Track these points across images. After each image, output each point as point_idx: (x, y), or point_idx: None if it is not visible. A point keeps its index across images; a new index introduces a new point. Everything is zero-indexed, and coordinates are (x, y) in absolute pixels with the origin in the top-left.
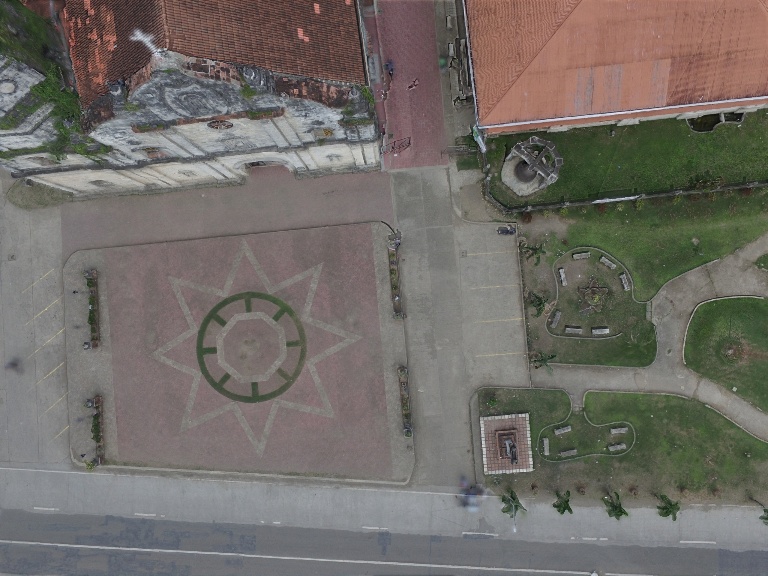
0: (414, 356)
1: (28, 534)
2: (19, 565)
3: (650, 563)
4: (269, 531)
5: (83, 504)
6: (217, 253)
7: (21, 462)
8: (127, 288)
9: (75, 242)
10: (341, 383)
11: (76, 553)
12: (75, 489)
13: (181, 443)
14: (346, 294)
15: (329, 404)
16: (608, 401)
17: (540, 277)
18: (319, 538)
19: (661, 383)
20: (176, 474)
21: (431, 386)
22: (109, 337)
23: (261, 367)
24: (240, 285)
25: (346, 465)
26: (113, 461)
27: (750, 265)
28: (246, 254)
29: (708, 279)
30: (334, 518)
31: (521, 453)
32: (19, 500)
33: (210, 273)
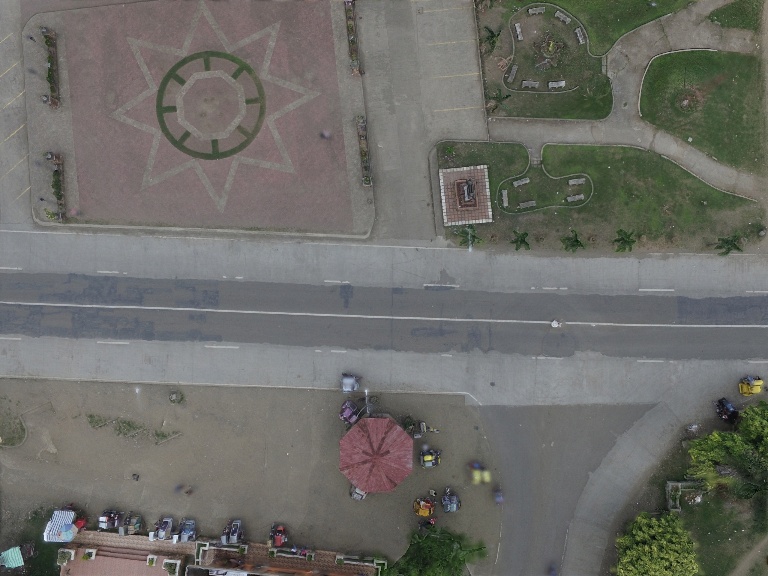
0: (373, 112)
1: None
2: None
3: (610, 311)
4: (231, 286)
5: (45, 263)
6: (175, 13)
7: None
8: (86, 49)
9: (34, 6)
10: (301, 139)
11: (39, 311)
12: (37, 248)
13: (142, 201)
14: (304, 51)
15: (289, 160)
16: (566, 153)
17: (496, 33)
18: (281, 292)
19: (618, 136)
20: (138, 232)
21: (390, 141)
22: (69, 98)
23: (221, 125)
24: (199, 44)
25: (307, 219)
26: (75, 219)
27: (703, 19)
28: (204, 14)
29: (662, 33)
30: (296, 272)
31: (480, 204)
32: None
33: (169, 33)
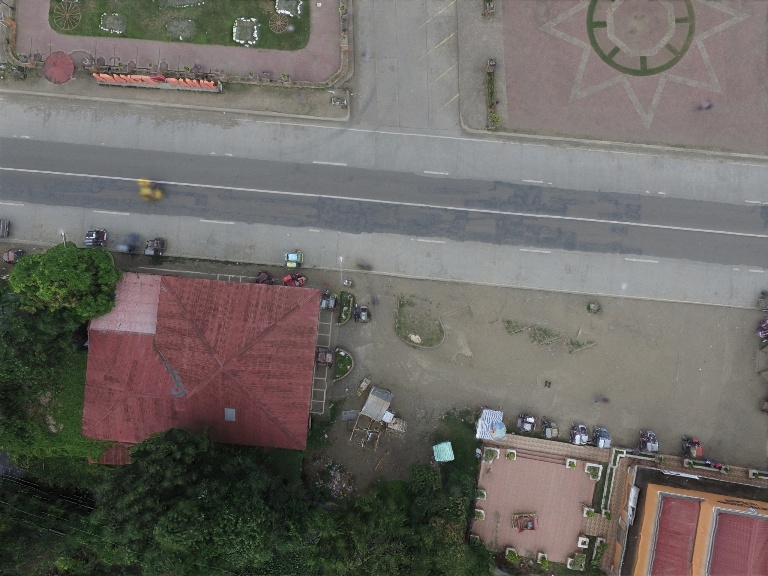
0: None
1: (417, 197)
2: (408, 226)
3: None
4: (654, 201)
5: (472, 169)
6: None
7: (411, 128)
8: None
9: None
10: (729, 59)
11: (464, 216)
12: (464, 155)
13: (570, 113)
14: None
15: (716, 79)
16: None
17: None
18: (702, 210)
19: None
20: (563, 143)
21: None
22: (501, 9)
23: (650, 42)
24: None
25: (732, 139)
26: (503, 128)
27: None
28: None
29: None
30: (717, 191)
31: None
32: (409, 164)
33: None
